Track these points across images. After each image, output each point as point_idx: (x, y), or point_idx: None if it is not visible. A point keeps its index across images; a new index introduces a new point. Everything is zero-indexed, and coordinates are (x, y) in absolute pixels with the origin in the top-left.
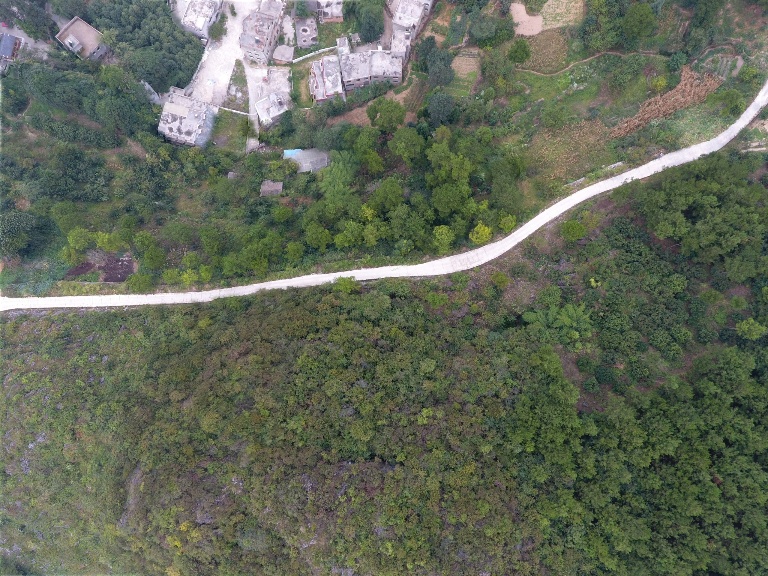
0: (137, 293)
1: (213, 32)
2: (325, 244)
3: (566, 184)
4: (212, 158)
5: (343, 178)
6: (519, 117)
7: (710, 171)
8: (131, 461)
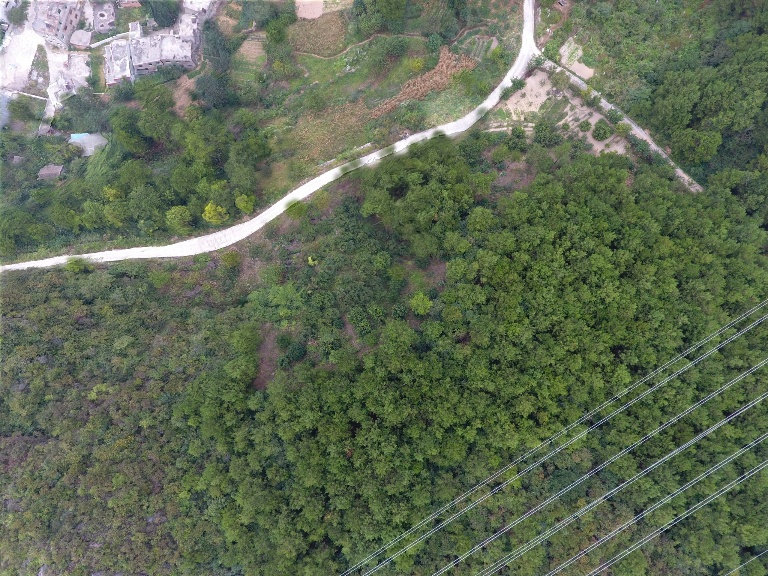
0: None
1: (13, 17)
2: (77, 225)
3: (316, 165)
4: None
5: (102, 160)
6: (292, 100)
7: (430, 150)
8: None
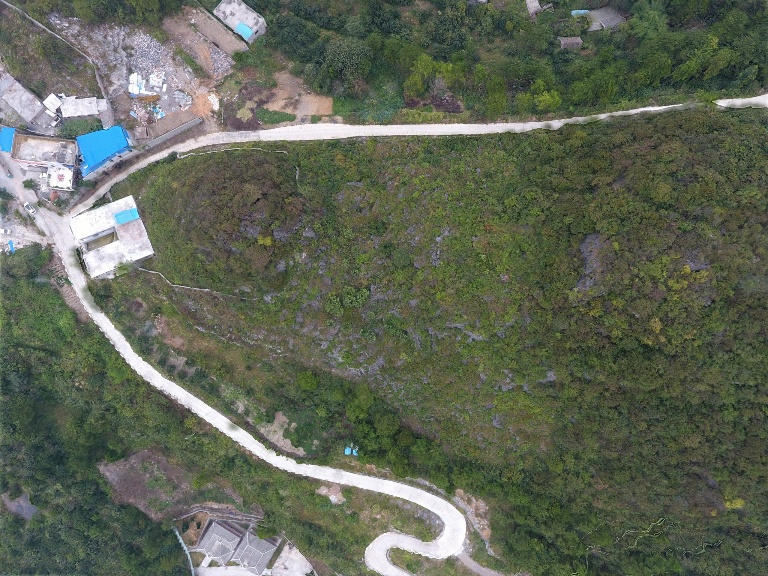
0: (478, 122)
1: None
2: (660, 78)
3: None
4: None
5: (666, 20)
6: None
7: None
8: (577, 235)
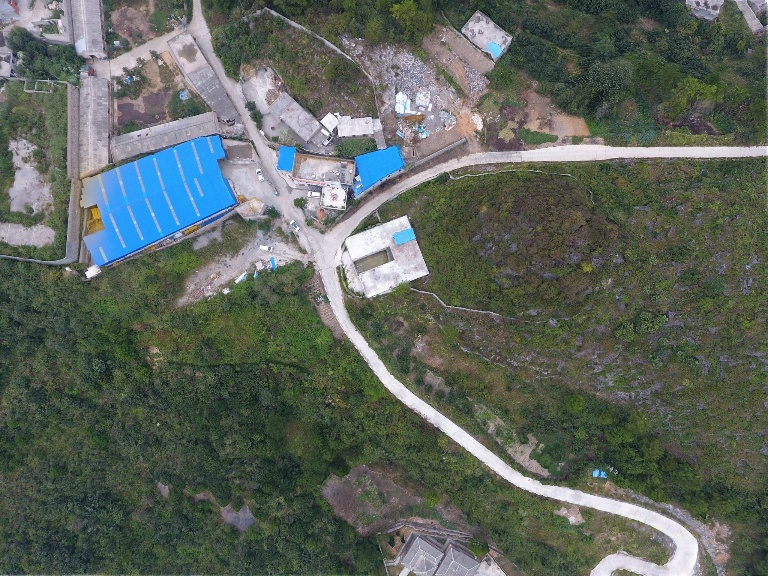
0: (741, 145)
1: None
2: None
3: None
4: None
5: None
6: None
7: None
8: None
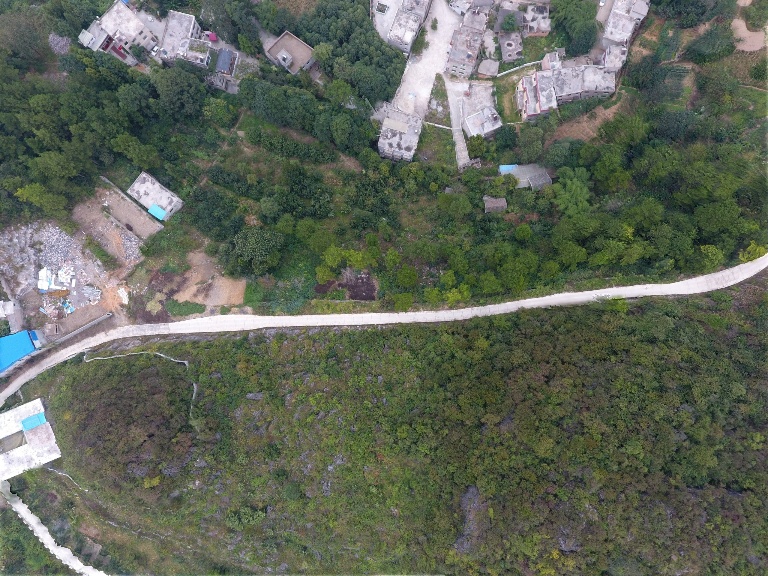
0: (389, 311)
1: (415, 46)
2: (576, 262)
3: None
4: (432, 174)
5: (587, 196)
6: (749, 134)
7: None
8: (459, 485)
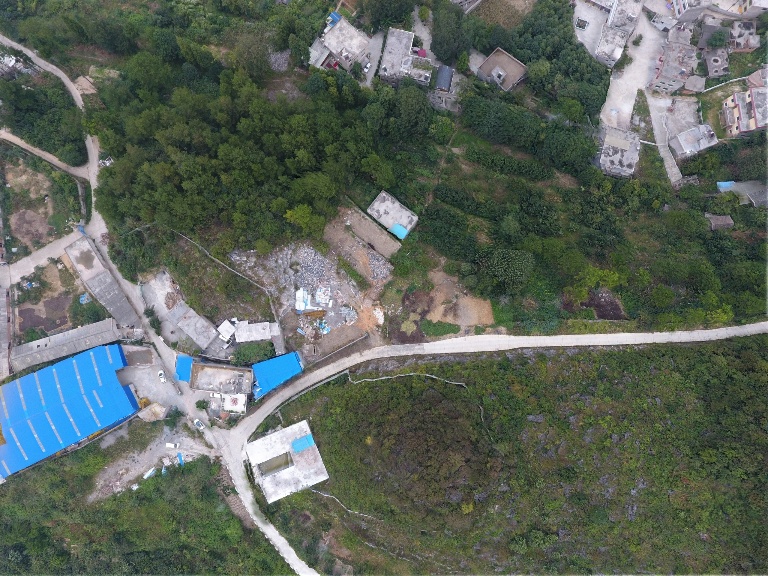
0: (644, 331)
1: (619, 62)
2: None
3: None
4: (654, 191)
5: None
6: None
7: None
8: None
